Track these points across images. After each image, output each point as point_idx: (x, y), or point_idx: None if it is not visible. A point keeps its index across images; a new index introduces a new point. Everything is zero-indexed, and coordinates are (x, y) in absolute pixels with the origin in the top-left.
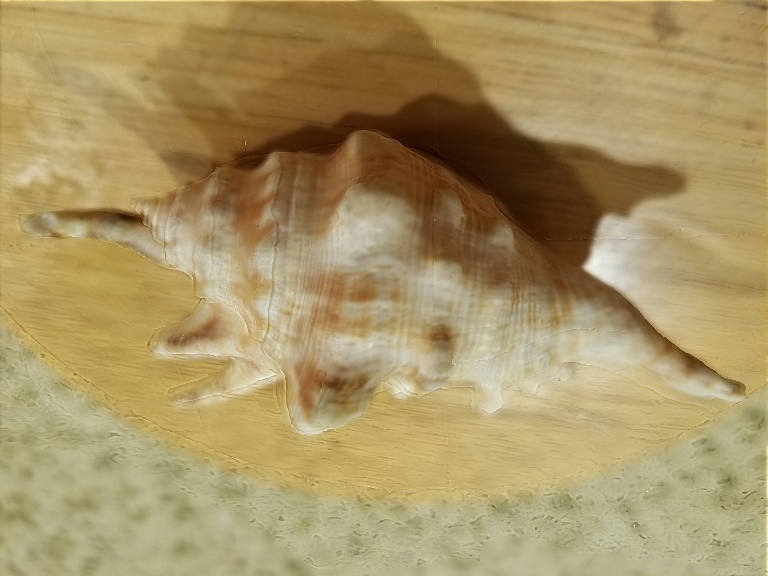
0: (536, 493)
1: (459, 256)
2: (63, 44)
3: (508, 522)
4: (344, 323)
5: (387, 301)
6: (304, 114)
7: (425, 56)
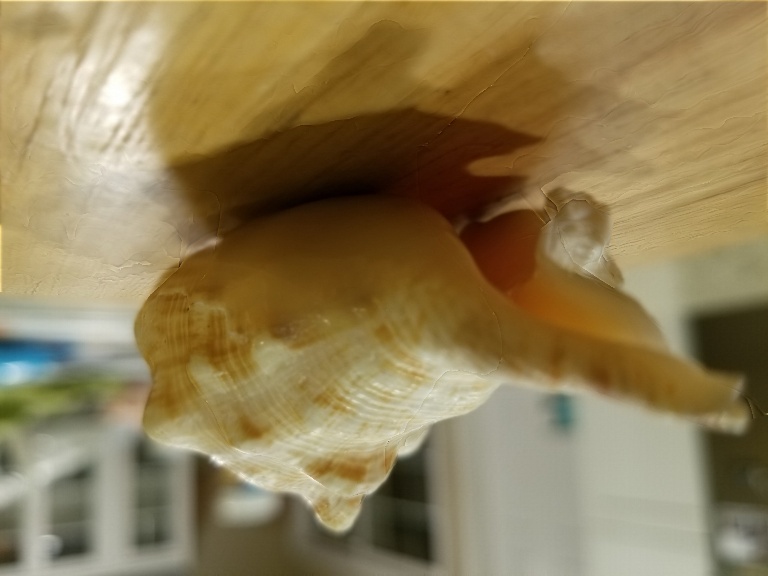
0: None
1: (244, 427)
2: (93, 274)
3: None
4: None
5: (254, 475)
6: (163, 234)
7: None
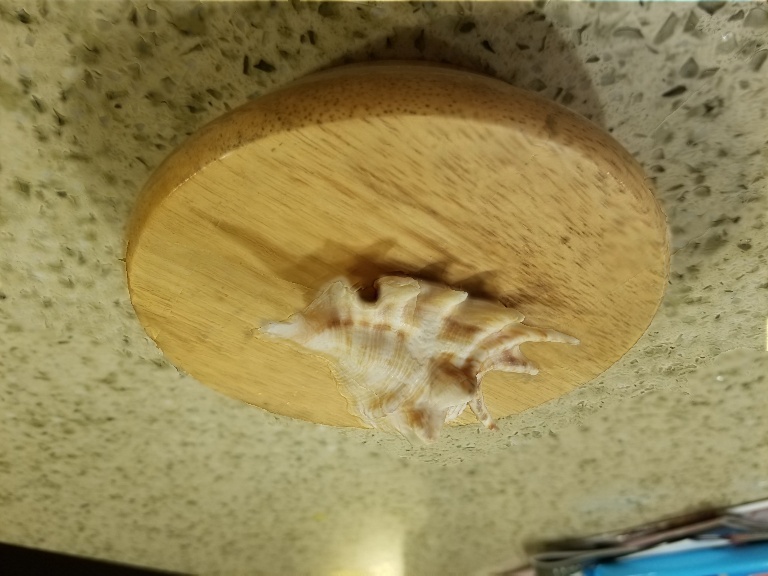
0: None
1: None
2: None
3: None
4: None
5: None
6: None
7: None
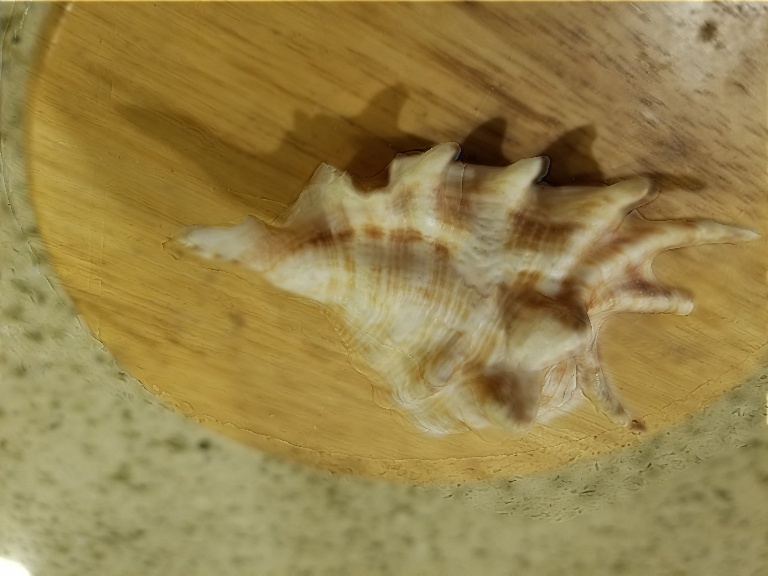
0: None
1: None
2: None
3: None
4: None
5: (422, 424)
6: None
7: None
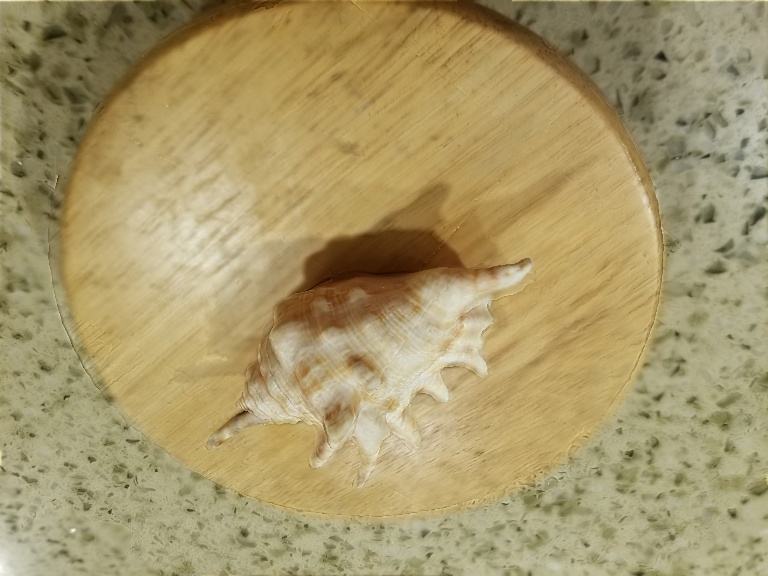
0: (741, 390)
1: (332, 323)
2: (180, 364)
3: (754, 429)
4: (309, 389)
5: (316, 366)
6: None
7: (285, 248)
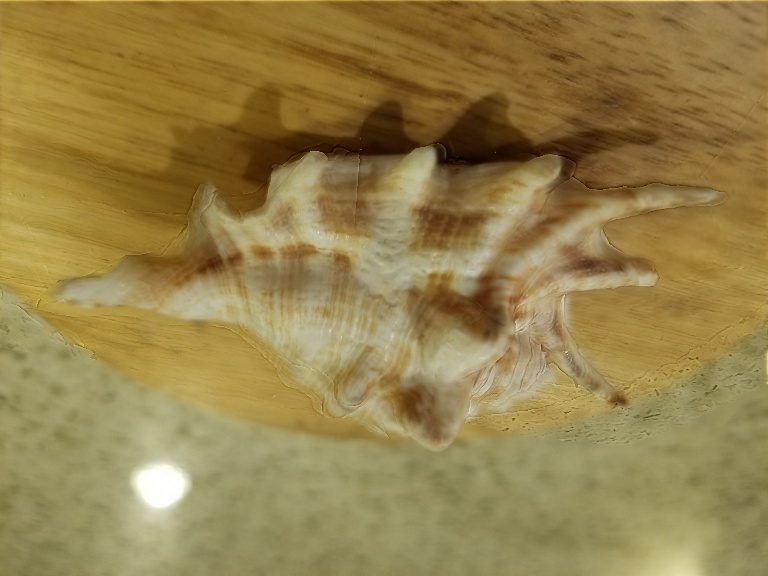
0: None
1: None
2: None
3: None
4: None
5: None
6: None
7: None
